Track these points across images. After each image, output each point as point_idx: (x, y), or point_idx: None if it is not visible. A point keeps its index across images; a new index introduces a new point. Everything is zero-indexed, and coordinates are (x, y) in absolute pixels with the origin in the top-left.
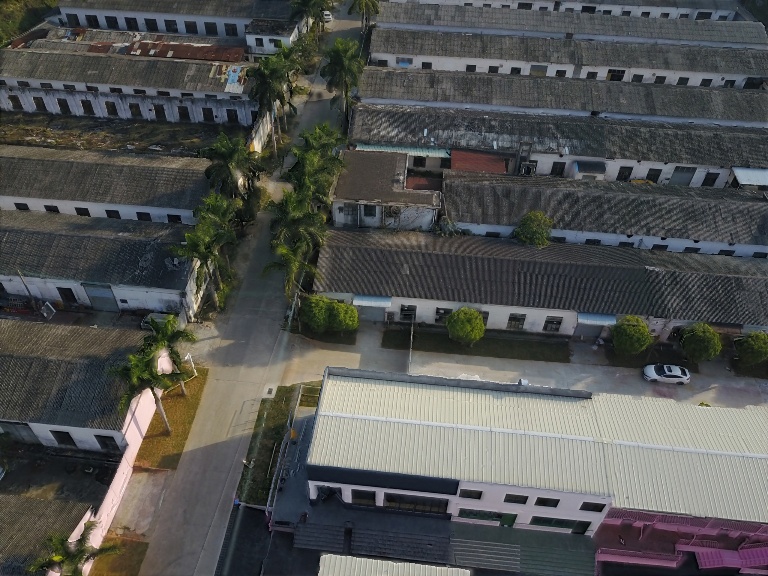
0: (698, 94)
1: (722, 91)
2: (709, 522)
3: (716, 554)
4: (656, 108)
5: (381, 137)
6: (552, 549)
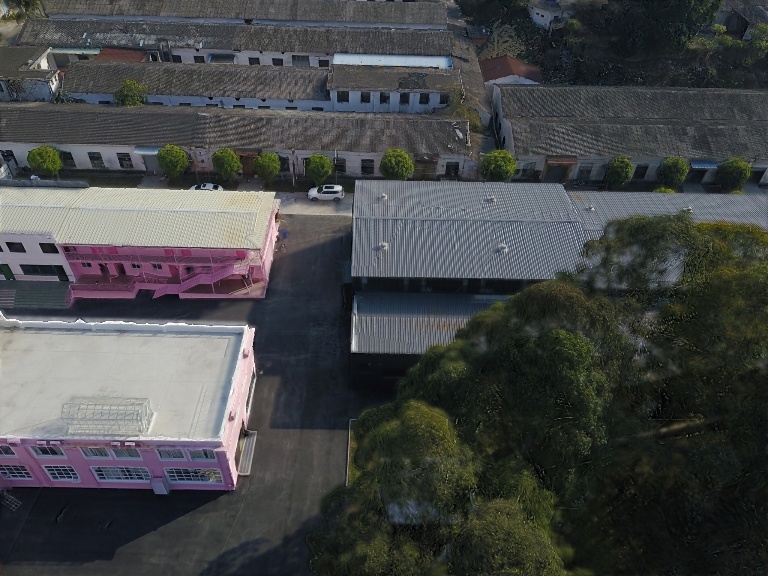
0: (336, 3)
1: (357, 1)
2: (137, 255)
3: (165, 287)
4: (297, 15)
5: (45, 40)
6: (40, 290)
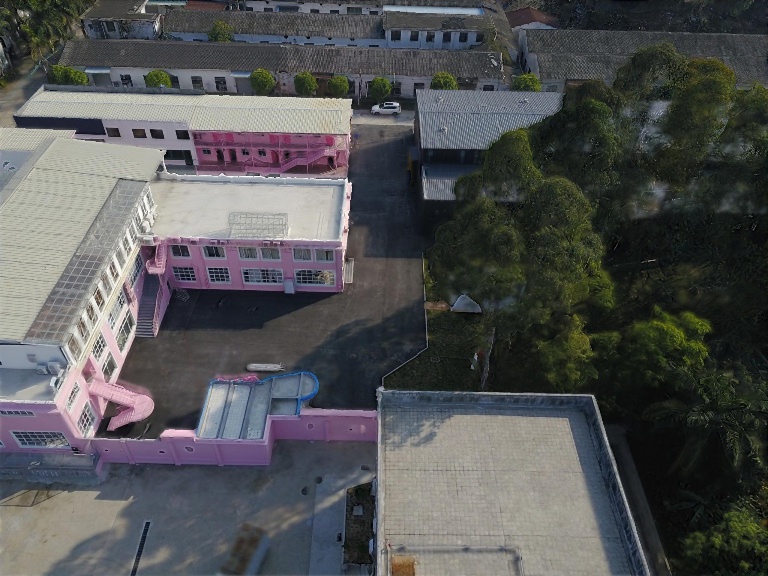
0: None
1: None
2: (250, 141)
3: (268, 170)
4: None
5: None
6: (172, 171)
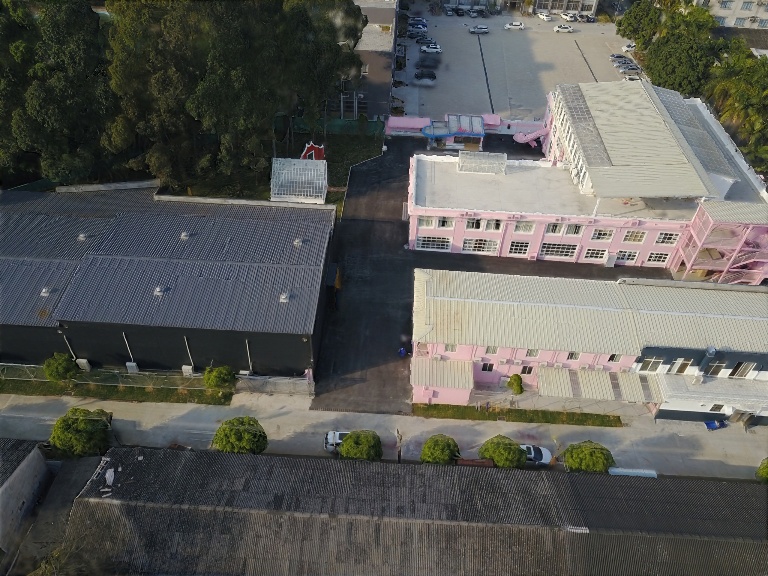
0: None
1: None
2: None
3: None
4: None
5: None
6: None
